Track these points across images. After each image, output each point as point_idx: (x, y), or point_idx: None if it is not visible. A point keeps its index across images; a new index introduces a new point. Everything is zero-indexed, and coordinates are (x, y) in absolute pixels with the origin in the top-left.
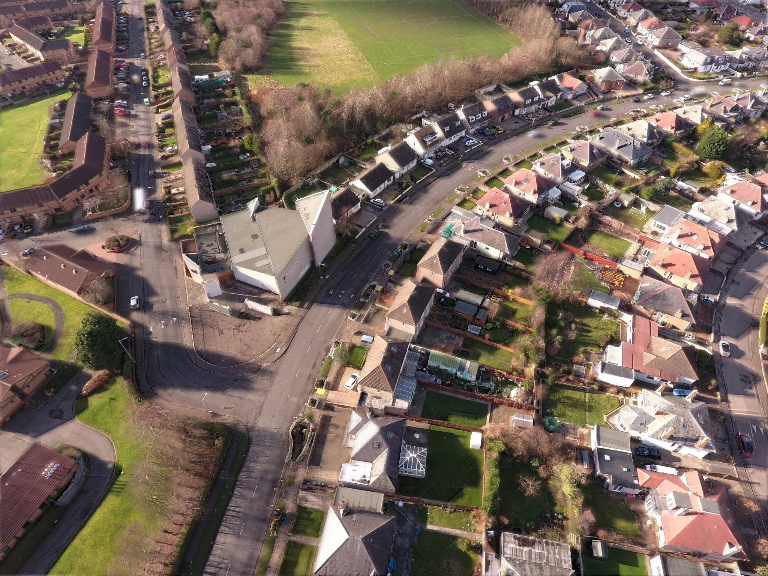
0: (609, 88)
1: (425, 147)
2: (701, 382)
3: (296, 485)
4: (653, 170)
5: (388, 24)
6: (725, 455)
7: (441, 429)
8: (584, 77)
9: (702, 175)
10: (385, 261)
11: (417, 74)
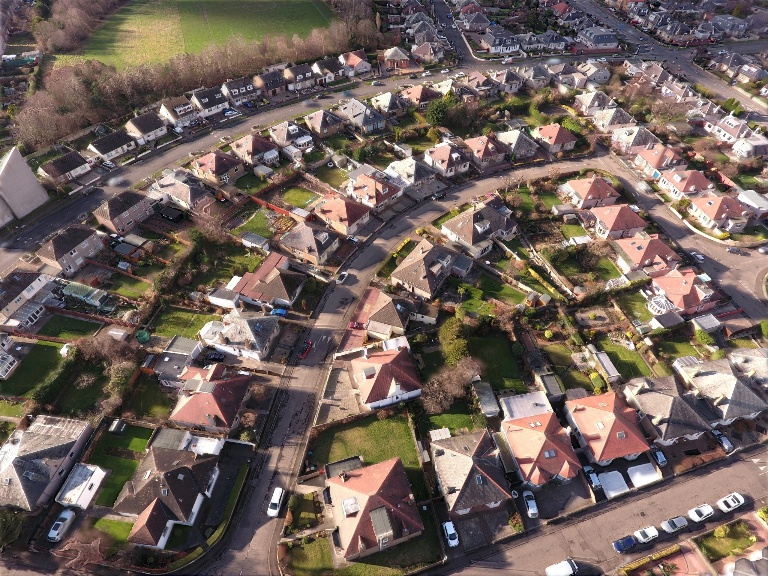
0: (396, 66)
1: (176, 116)
2: None
3: None
4: (385, 136)
5: (226, 9)
6: None
7: (47, 343)
8: (376, 57)
9: (427, 140)
10: (83, 213)
11: (203, 52)
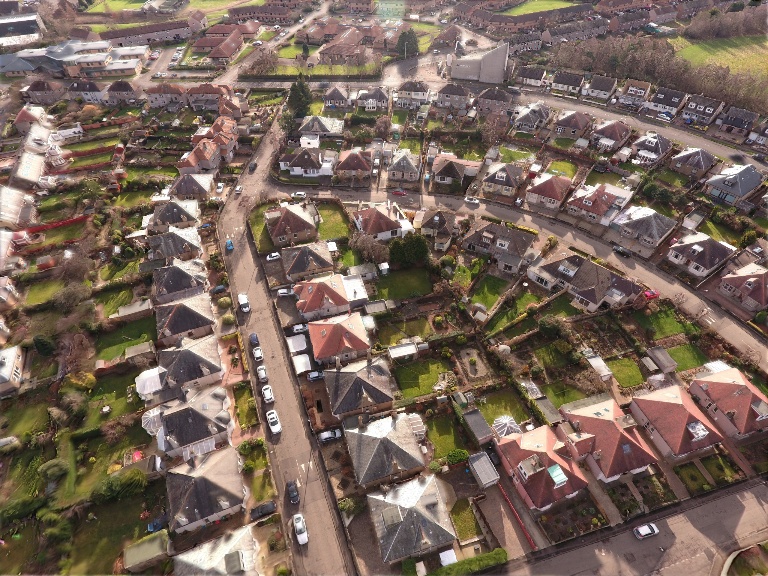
0: None
1: (625, 92)
2: (439, 187)
3: None
4: None
5: None
6: None
7: None
8: None
9: None
10: None
11: (741, 74)
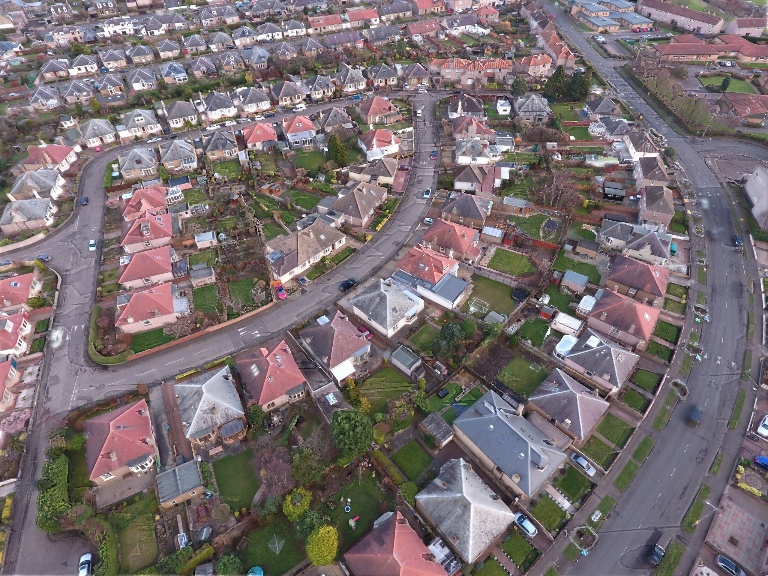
0: None
1: None
2: None
3: None
4: (447, 404)
5: None
6: None
7: None
8: None
9: None
10: None
11: None
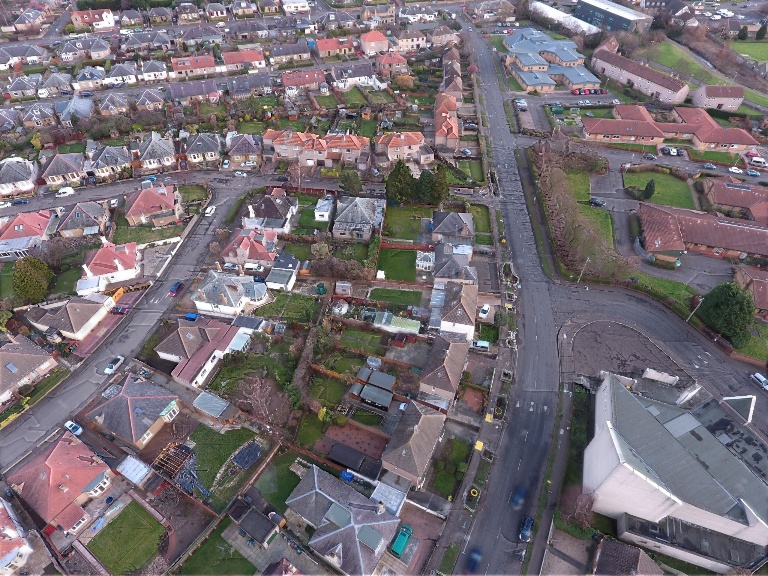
0: None
1: None
2: None
3: (499, 254)
4: None
5: None
6: (199, 281)
7: None
8: None
9: None
10: None
11: None
